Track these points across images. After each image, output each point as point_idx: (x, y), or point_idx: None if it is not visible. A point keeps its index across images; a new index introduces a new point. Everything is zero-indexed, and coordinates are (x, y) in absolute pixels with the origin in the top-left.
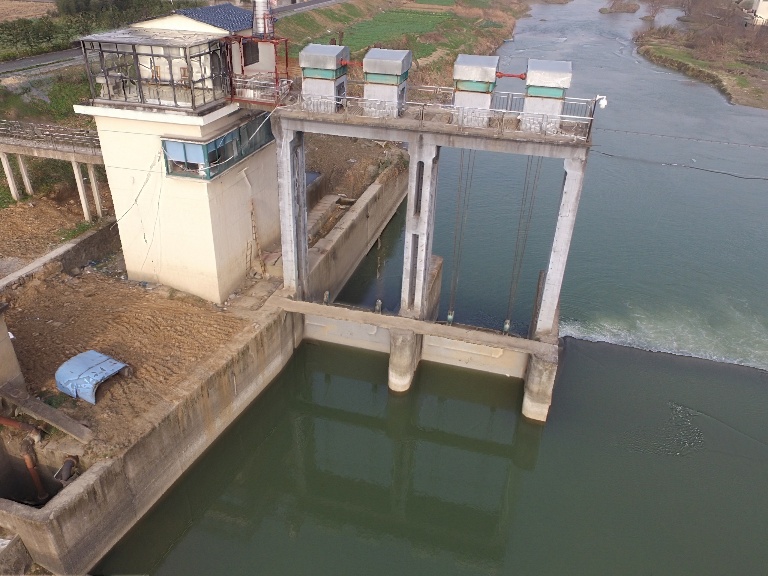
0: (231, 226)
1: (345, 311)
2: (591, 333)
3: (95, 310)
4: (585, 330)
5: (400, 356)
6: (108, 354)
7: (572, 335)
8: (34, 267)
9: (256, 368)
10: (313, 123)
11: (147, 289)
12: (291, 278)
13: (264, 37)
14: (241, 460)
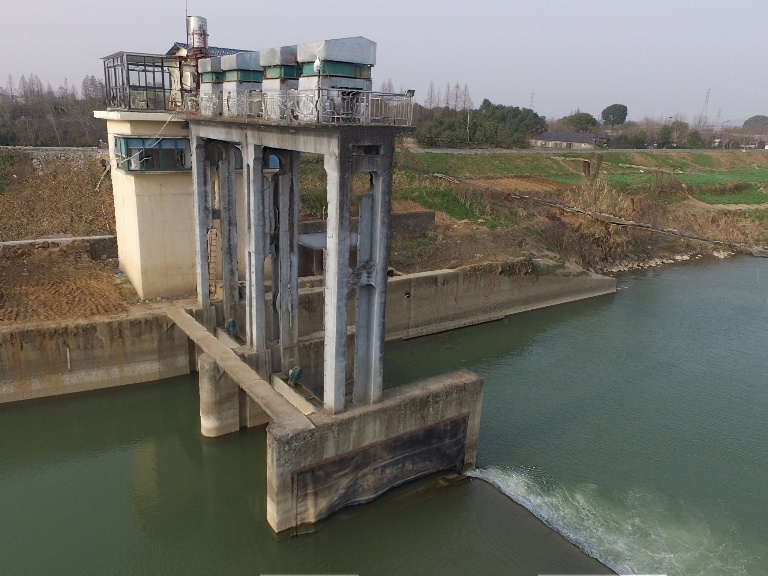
0: (174, 232)
1: (200, 329)
2: (540, 498)
3: (60, 275)
4: (536, 491)
5: (201, 387)
6: (7, 295)
7: (506, 487)
8: (64, 239)
9: (109, 357)
10: (202, 127)
11: (115, 276)
12: (200, 293)
13: (192, 51)
14: (75, 445)
